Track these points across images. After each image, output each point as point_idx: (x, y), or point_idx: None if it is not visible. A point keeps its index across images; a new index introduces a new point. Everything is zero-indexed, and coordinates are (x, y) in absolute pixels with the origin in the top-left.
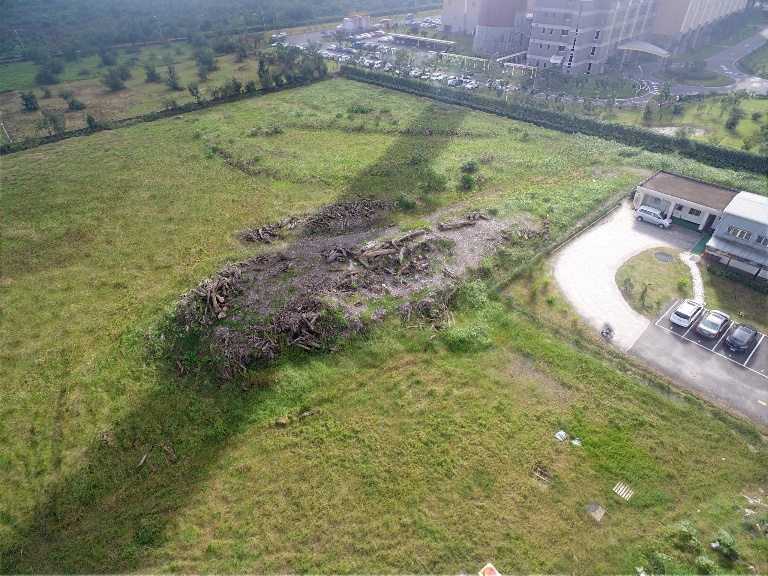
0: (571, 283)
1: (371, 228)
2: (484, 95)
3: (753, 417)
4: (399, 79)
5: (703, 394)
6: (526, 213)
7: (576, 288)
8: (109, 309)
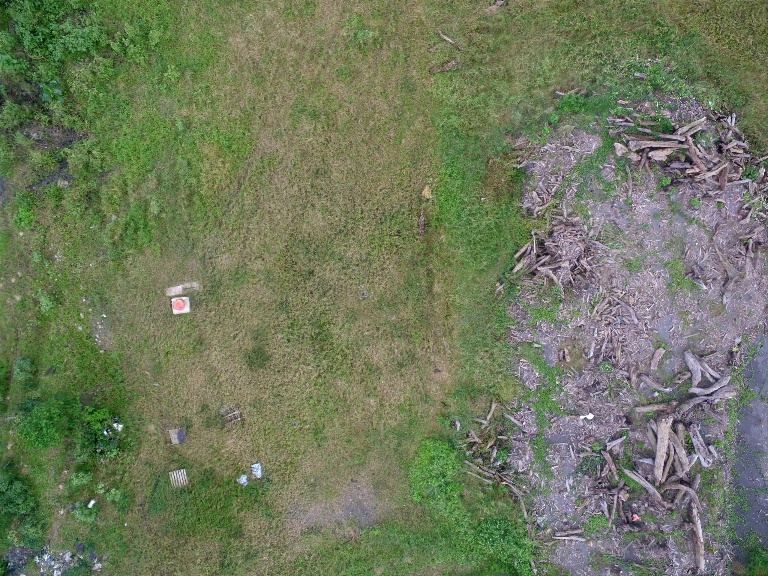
0: None
1: None
2: None
3: None
4: None
5: None
6: None
7: None
8: (759, 13)
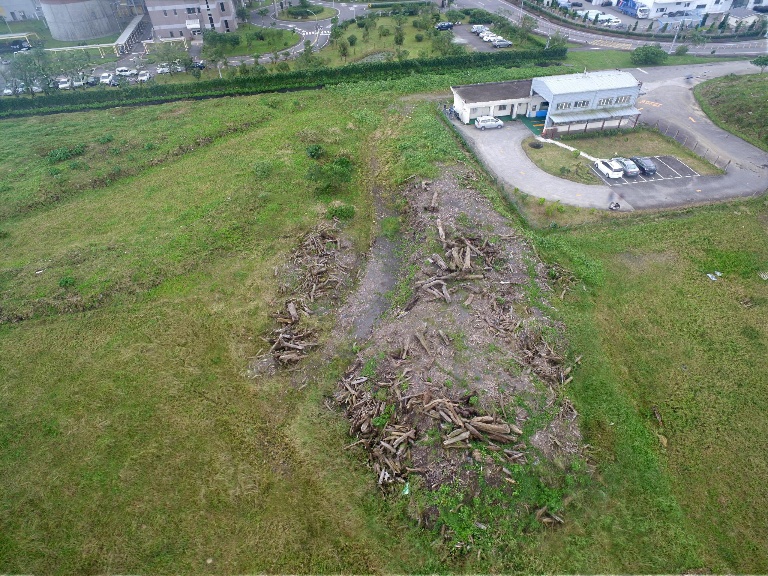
0: (544, 192)
1: (366, 255)
2: (177, 82)
3: (710, 200)
4: (46, 98)
5: (686, 205)
6: (436, 163)
7: (551, 193)
8: None
